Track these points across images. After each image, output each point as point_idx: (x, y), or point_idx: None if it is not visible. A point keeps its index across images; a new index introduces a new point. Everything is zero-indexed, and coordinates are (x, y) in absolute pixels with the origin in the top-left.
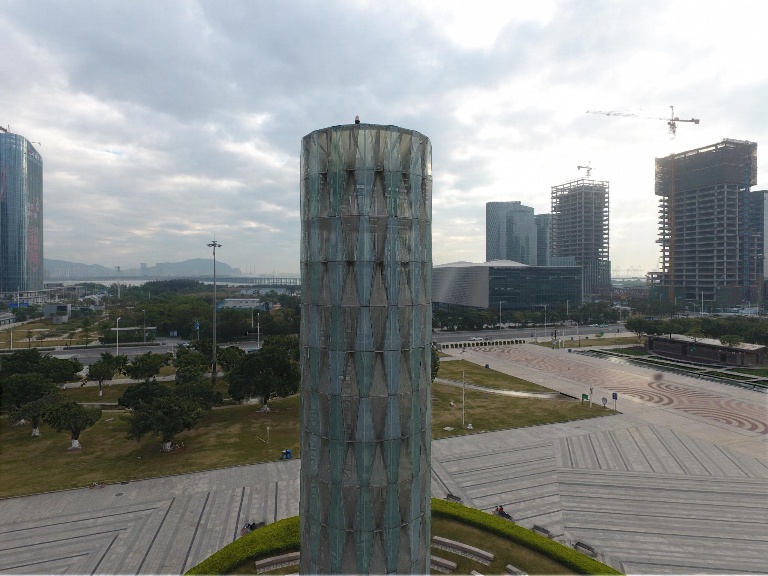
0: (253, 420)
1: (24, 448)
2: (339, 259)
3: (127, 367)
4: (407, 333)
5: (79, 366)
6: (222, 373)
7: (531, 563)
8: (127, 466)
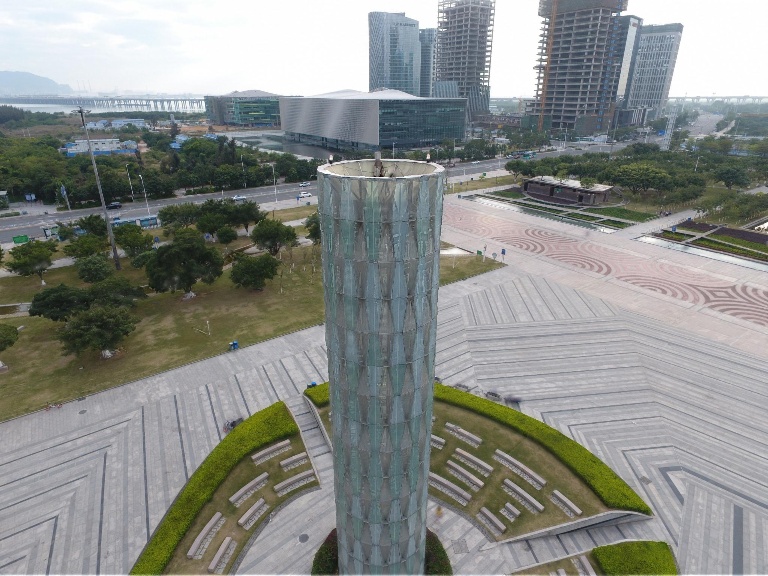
0: (183, 309)
1: None
2: (377, 298)
3: (12, 264)
4: (427, 342)
5: None
6: (123, 254)
7: (462, 419)
8: (73, 380)
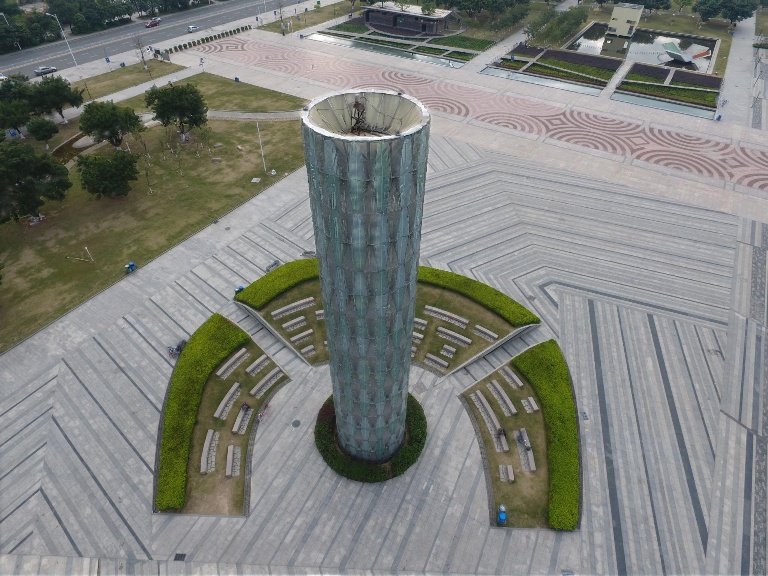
0: (39, 237)
1: None
2: (385, 242)
3: None
4: (417, 262)
5: None
6: None
7: None
8: None
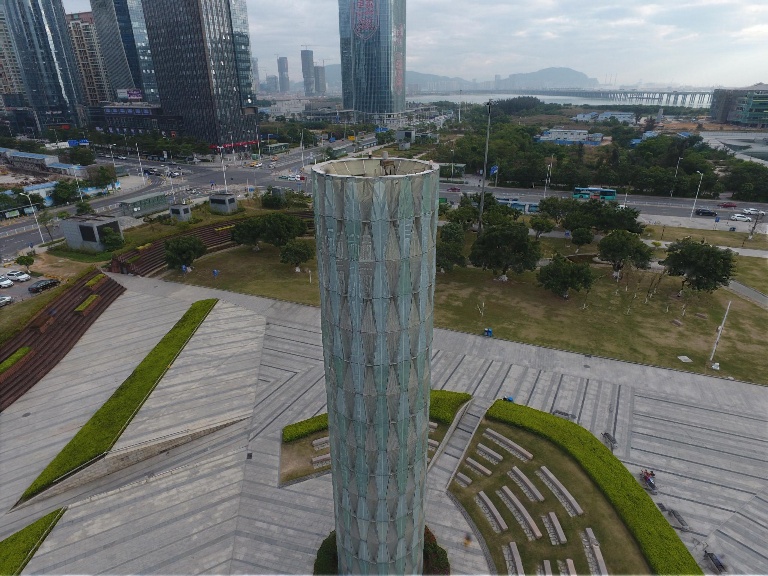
0: (486, 287)
1: None
2: None
3: None
4: (372, 353)
5: None
6: None
7: (614, 540)
8: None
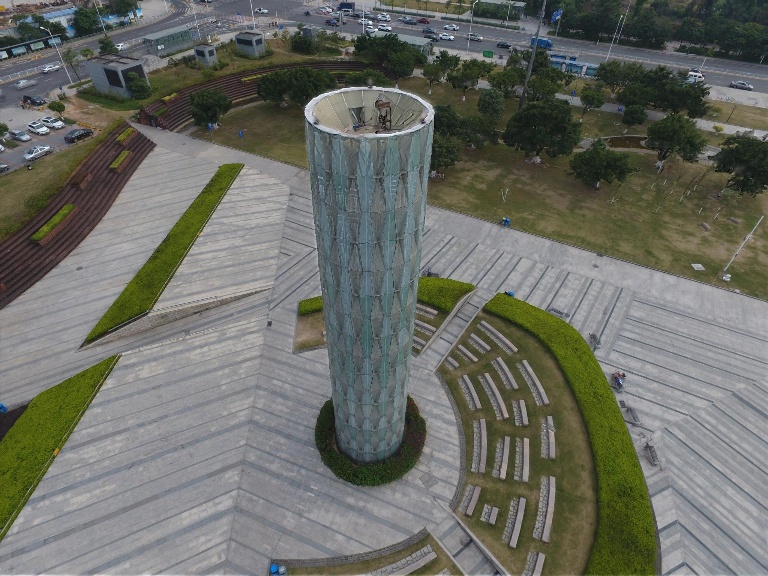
0: (515, 170)
1: None
2: None
3: (448, 75)
4: (359, 286)
5: (423, 59)
6: None
7: (569, 428)
8: None
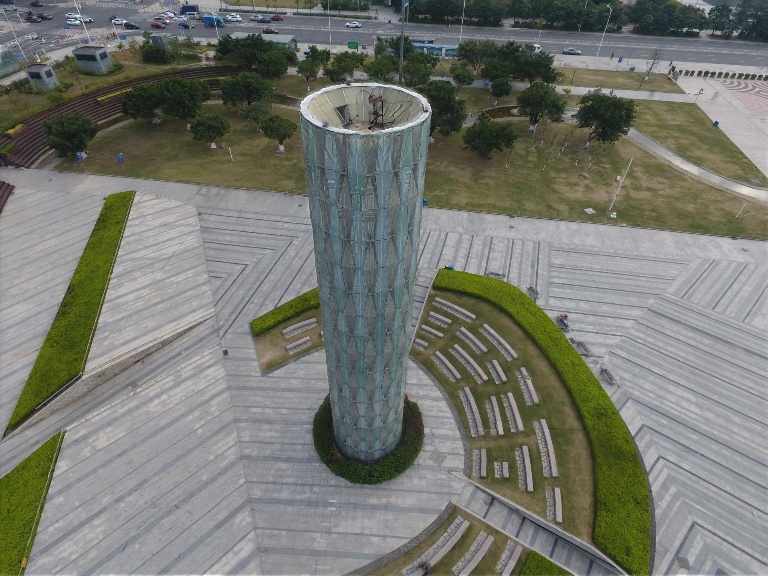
0: None
1: (252, 142)
2: (321, 227)
3: (325, 70)
4: (373, 284)
5: (293, 56)
6: None
7: (541, 374)
8: None
